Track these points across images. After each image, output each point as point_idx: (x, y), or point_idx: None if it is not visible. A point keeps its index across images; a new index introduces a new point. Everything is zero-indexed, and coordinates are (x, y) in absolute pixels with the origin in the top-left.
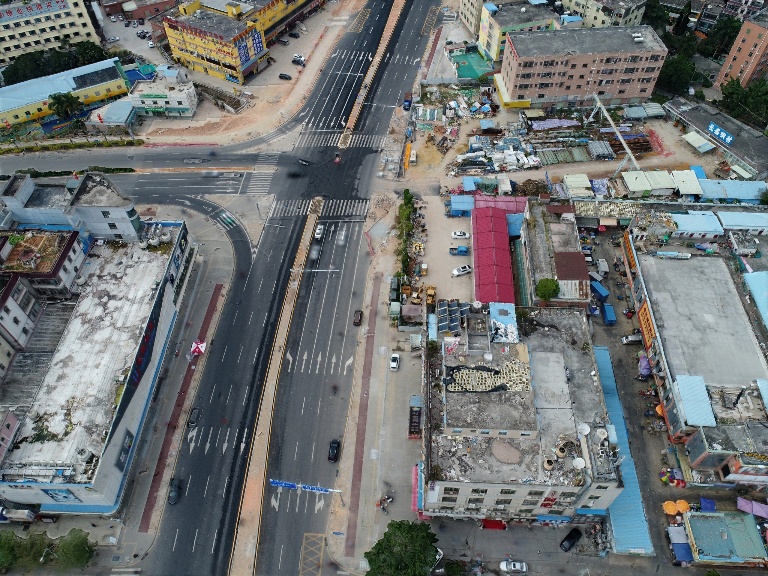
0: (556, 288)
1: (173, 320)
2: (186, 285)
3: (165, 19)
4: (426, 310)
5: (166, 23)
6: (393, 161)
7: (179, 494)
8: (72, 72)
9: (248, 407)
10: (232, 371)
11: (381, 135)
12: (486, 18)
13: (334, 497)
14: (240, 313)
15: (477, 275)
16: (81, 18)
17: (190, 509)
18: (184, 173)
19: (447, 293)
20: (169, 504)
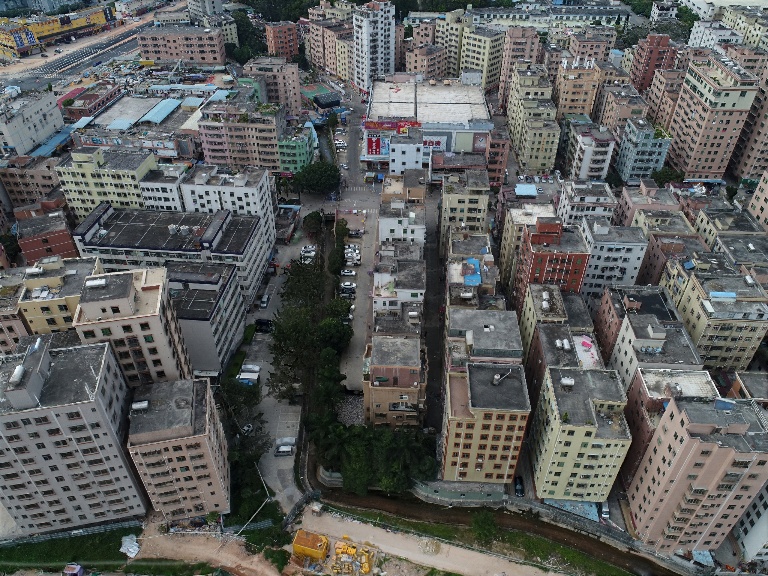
0: (69, 100)
1: None
2: None
3: None
4: None
5: None
6: None
7: None
8: None
9: None
10: None
11: (71, 75)
12: None
13: None
14: None
15: None
16: None
17: None
18: None
19: None
20: None
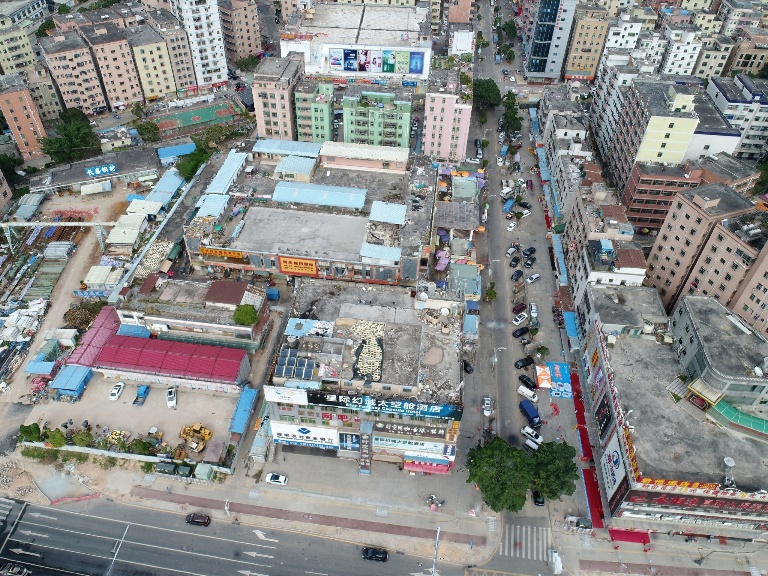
0: (251, 306)
1: None
2: None
3: None
4: (281, 387)
5: None
6: None
7: None
8: None
9: None
10: None
11: None
12: None
13: (427, 556)
14: None
15: (197, 375)
16: None
17: None
18: None
19: (196, 417)
20: None
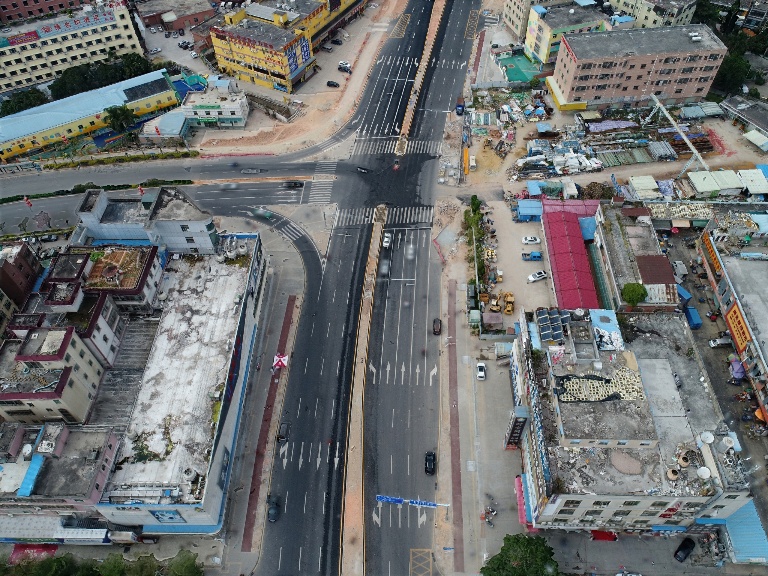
0: (644, 292)
1: (254, 333)
2: (262, 298)
3: (212, 29)
4: (526, 319)
5: (213, 33)
6: (452, 167)
7: (278, 511)
8: (121, 85)
9: (337, 420)
10: (316, 384)
11: (437, 141)
12: (535, 20)
13: (436, 511)
14: (317, 325)
15: (557, 281)
16: (127, 30)
17: (291, 526)
18: (243, 184)
19: (525, 299)
20: (269, 522)
